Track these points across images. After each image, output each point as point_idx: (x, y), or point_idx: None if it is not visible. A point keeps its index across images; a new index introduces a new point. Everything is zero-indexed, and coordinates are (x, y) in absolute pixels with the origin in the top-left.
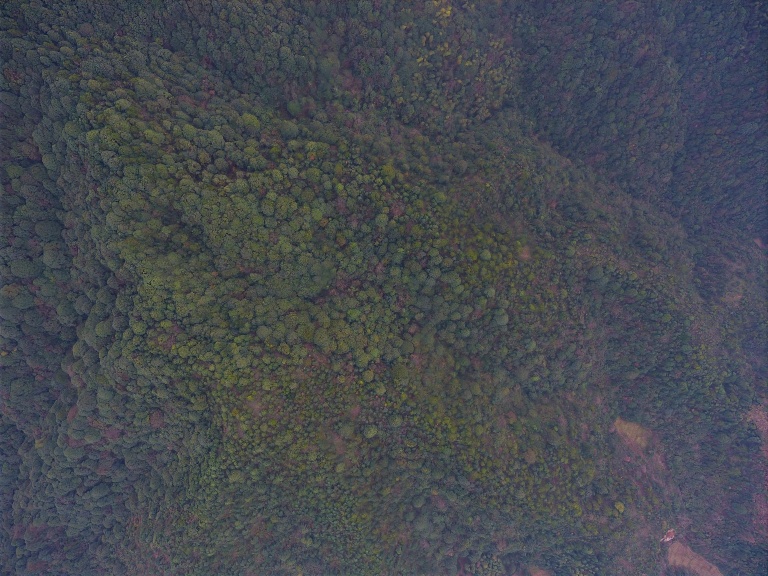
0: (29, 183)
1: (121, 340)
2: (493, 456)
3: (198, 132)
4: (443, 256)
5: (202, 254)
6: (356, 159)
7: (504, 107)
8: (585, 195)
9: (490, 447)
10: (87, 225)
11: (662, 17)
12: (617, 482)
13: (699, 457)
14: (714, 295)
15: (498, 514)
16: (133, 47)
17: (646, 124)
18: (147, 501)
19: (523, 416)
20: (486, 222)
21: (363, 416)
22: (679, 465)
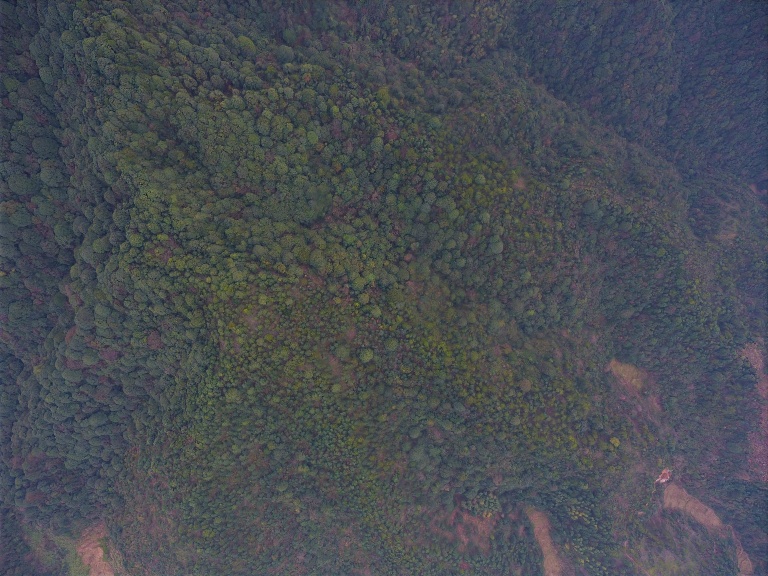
0: (26, 97)
1: (118, 254)
2: (488, 382)
3: (194, 48)
4: (438, 180)
5: (198, 172)
6: (351, 82)
7: (499, 48)
8: (580, 134)
9: (485, 374)
10: (84, 140)
11: None
12: (612, 419)
13: (694, 398)
14: (708, 234)
15: (494, 442)
16: None
17: (641, 64)
18: (145, 429)
19: (518, 348)
20: (481, 152)
21: (359, 339)
22: (674, 406)
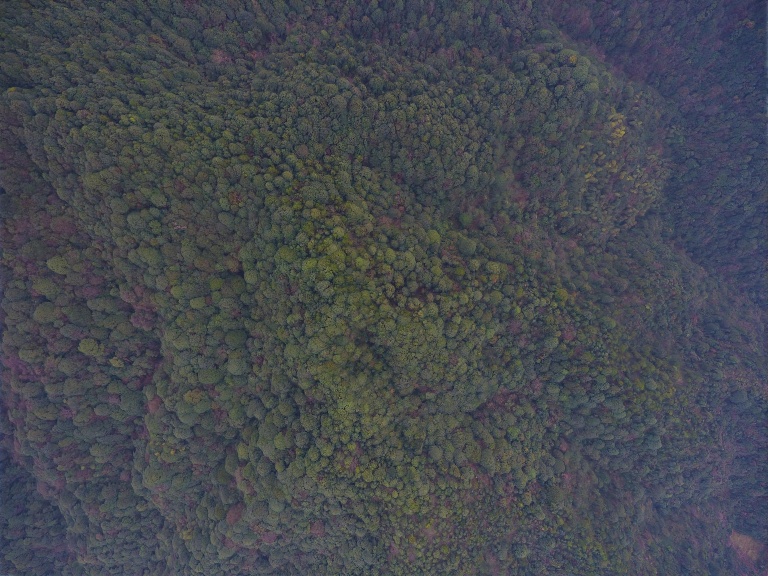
0: (228, 296)
1: (303, 457)
2: None
3: (397, 256)
4: (610, 383)
5: (385, 373)
6: (533, 282)
7: (647, 214)
8: (723, 309)
9: (633, 572)
10: (279, 340)
11: None
12: None
13: None
14: None
15: None
16: (341, 167)
17: None
18: None
19: (657, 535)
20: (643, 344)
21: (518, 537)
22: None
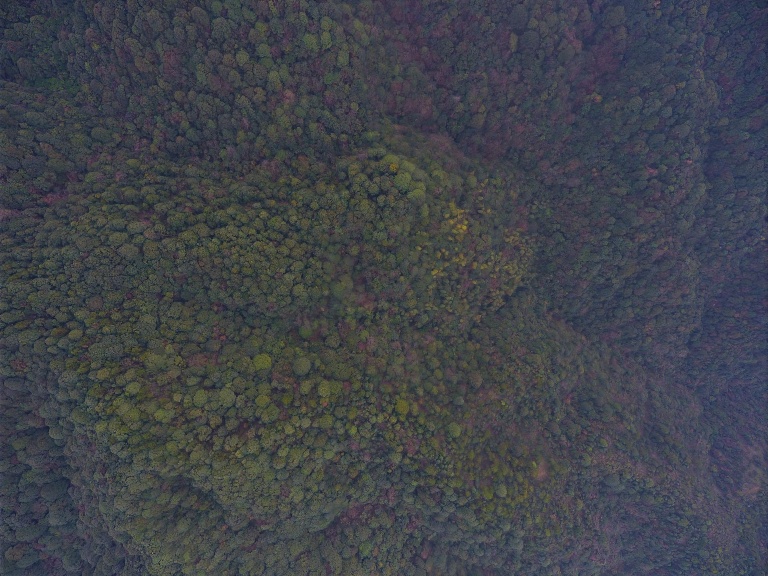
0: (35, 454)
1: None
2: None
3: (209, 397)
4: (458, 494)
5: (212, 512)
6: (370, 398)
7: (518, 291)
8: (600, 383)
9: None
10: None
11: (682, 220)
12: None
13: None
14: (731, 486)
15: None
16: (143, 312)
17: (663, 310)
18: None
19: None
20: (501, 441)
21: None
22: None
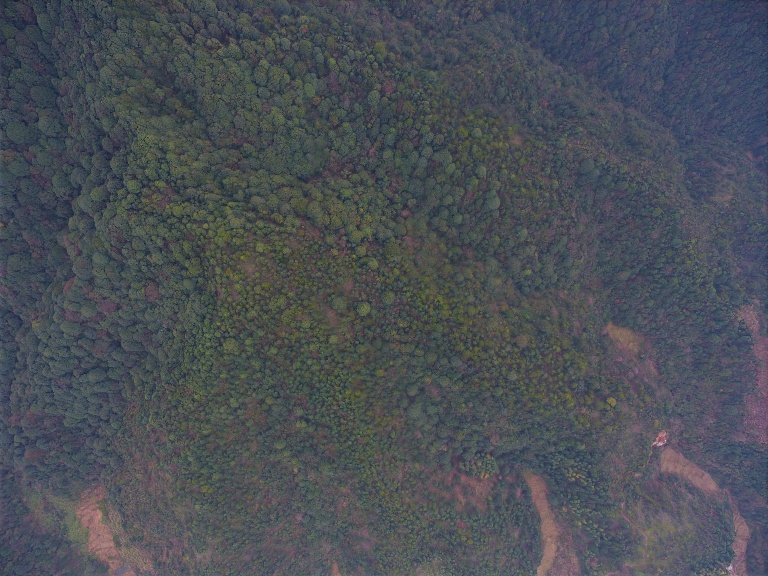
0: (24, 44)
1: (116, 201)
2: (485, 337)
3: None
4: (435, 133)
5: (196, 121)
6: (348, 35)
7: (496, 11)
8: (577, 97)
9: (482, 329)
10: (82, 88)
11: None
12: (609, 381)
13: (691, 361)
14: (705, 196)
15: (491, 398)
16: None
17: (637, 27)
18: (143, 385)
19: (515, 307)
20: (478, 108)
21: (356, 291)
22: (671, 370)
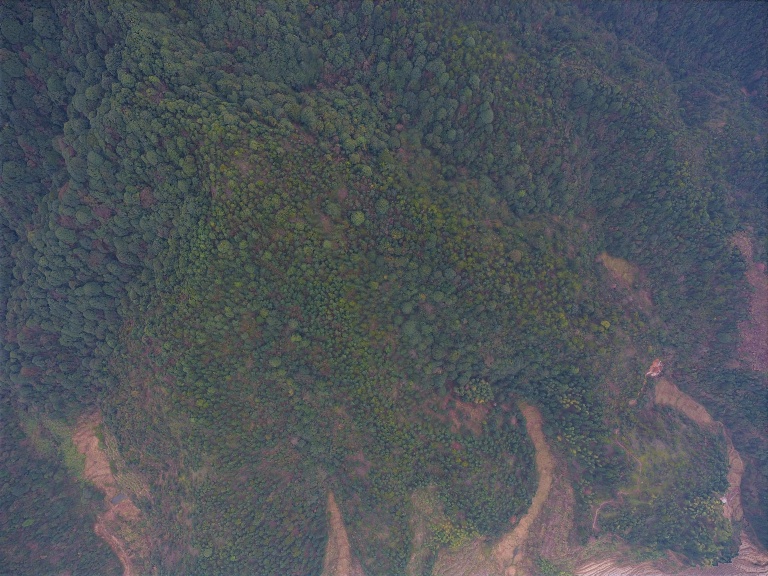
0: None
1: None
2: (479, 249)
3: None
4: (428, 42)
5: (190, 22)
6: None
7: None
8: (571, 24)
9: (476, 242)
10: None
11: None
12: (603, 307)
13: (685, 290)
14: (698, 122)
15: (485, 313)
16: None
17: None
18: (139, 299)
19: (509, 226)
20: None
21: (350, 199)
22: (665, 300)
